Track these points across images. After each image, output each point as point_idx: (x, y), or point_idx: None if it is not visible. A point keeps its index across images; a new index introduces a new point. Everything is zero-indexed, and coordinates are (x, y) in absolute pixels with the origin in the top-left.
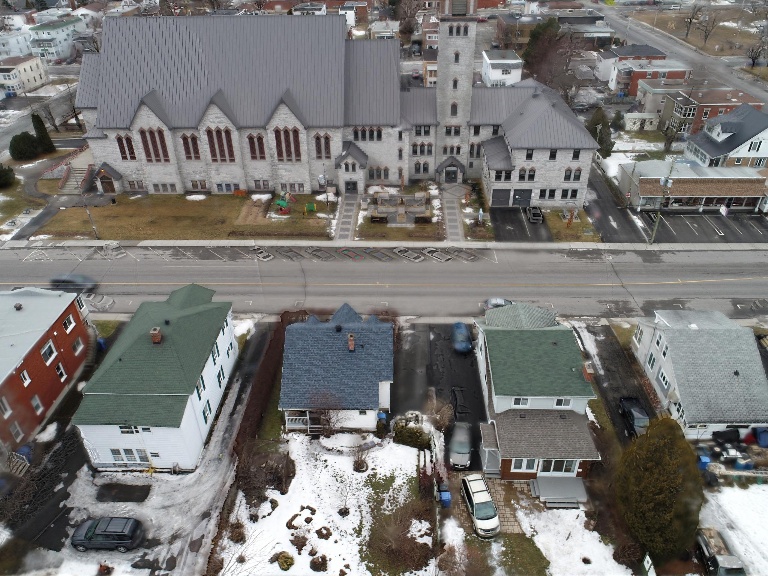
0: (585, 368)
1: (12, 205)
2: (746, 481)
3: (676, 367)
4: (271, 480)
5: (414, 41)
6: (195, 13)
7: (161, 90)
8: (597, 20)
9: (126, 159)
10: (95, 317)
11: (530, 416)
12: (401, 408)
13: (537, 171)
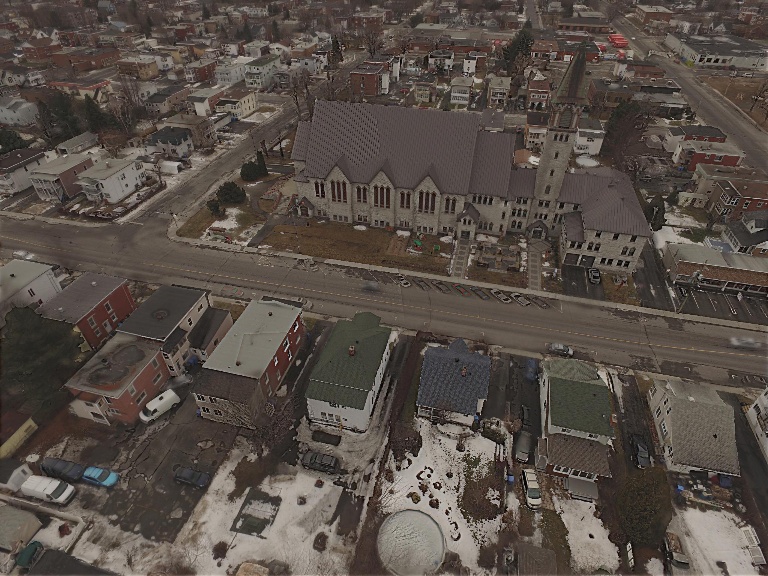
0: (612, 418)
1: (245, 218)
2: (705, 507)
3: (674, 424)
4: (408, 447)
5: (520, 95)
6: (354, 48)
7: (348, 155)
8: (674, 91)
9: (319, 196)
10: None
11: (571, 440)
12: (488, 413)
13: (602, 245)
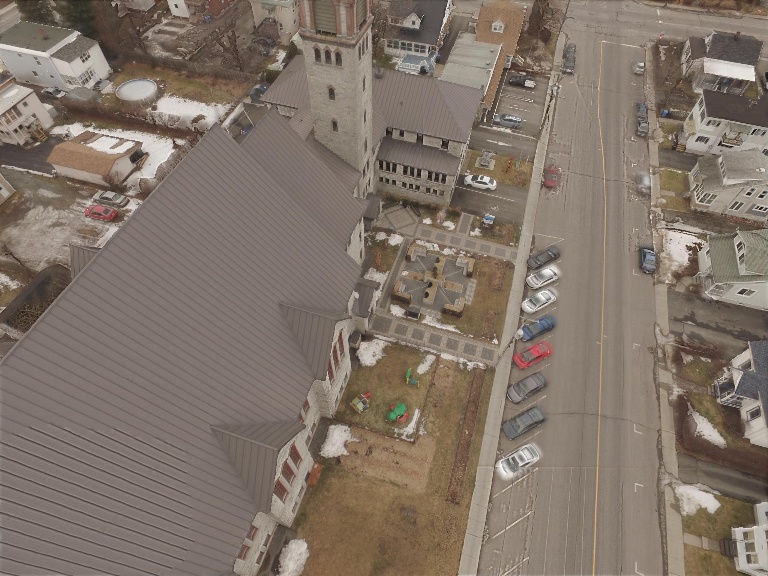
0: None
1: None
2: None
3: None
4: None
5: None
6: None
7: None
8: None
9: None
10: None
11: None
12: None
13: None
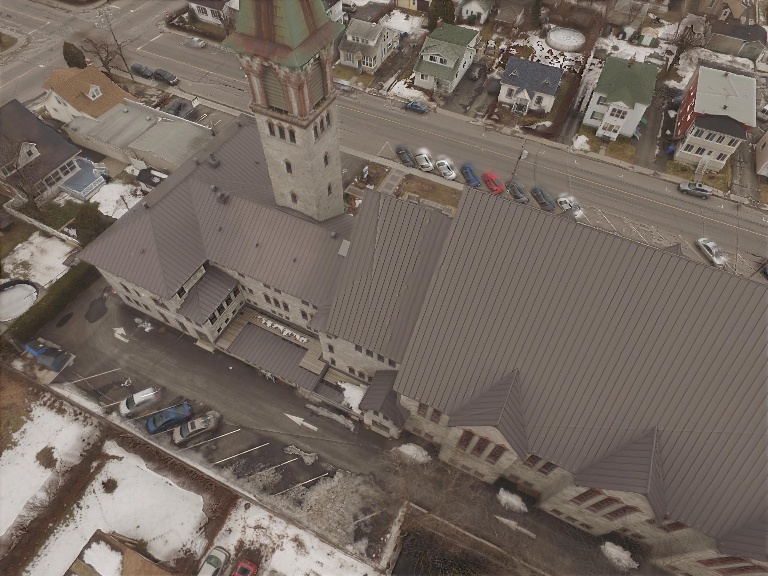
0: None
1: None
2: None
3: None
4: None
5: None
6: None
7: None
8: None
9: None
10: None
11: None
12: None
13: None
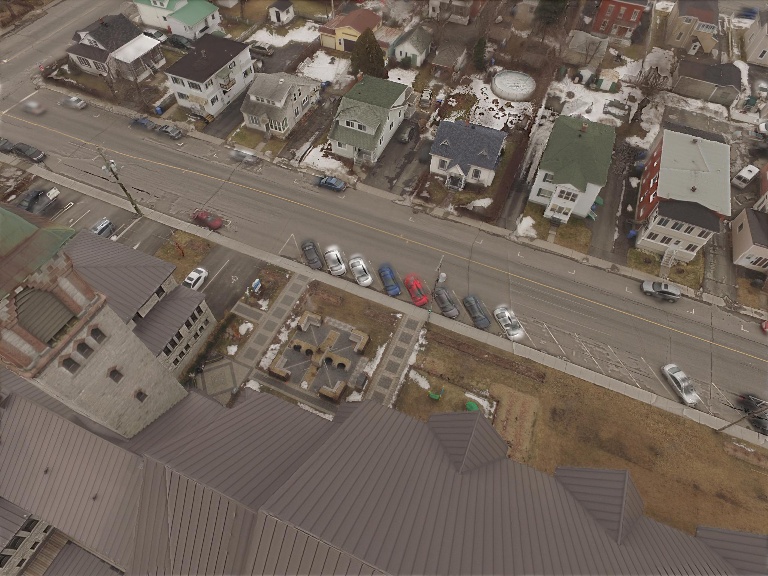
0: None
1: None
2: None
3: None
4: None
5: None
6: None
7: None
8: None
9: None
10: (651, 277)
11: None
12: None
13: None
